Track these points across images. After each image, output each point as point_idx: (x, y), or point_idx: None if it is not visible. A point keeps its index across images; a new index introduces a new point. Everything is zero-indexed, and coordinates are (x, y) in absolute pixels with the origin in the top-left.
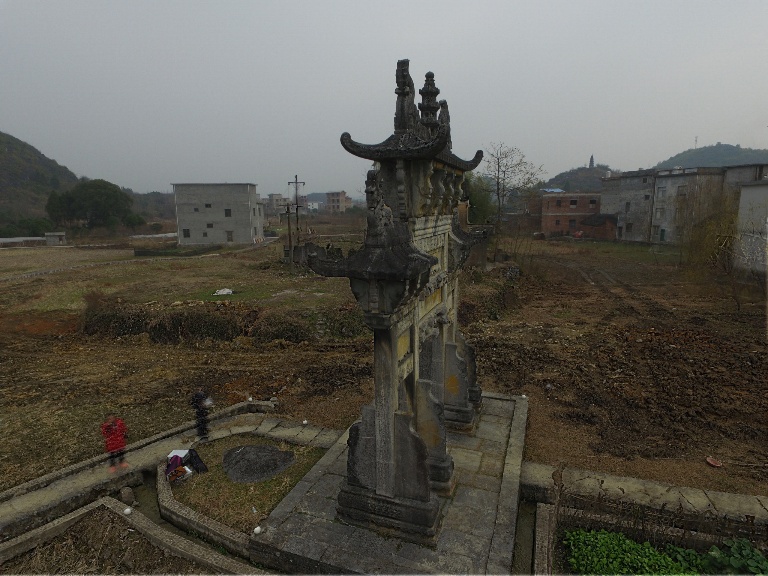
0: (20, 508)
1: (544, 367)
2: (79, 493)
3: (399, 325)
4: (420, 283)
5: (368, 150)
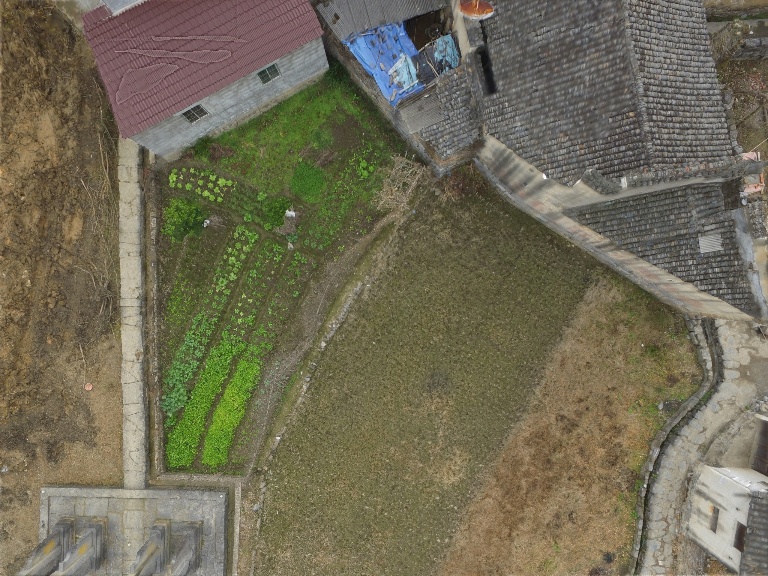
0: None
1: None
2: None
3: None
4: None
5: None
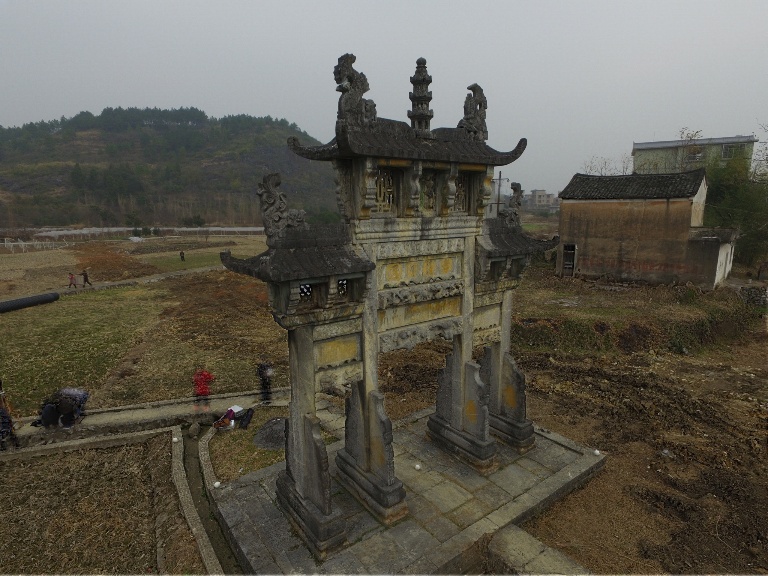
0: (135, 416)
1: (690, 427)
2: (167, 418)
3: (321, 329)
4: (360, 289)
5: (310, 152)
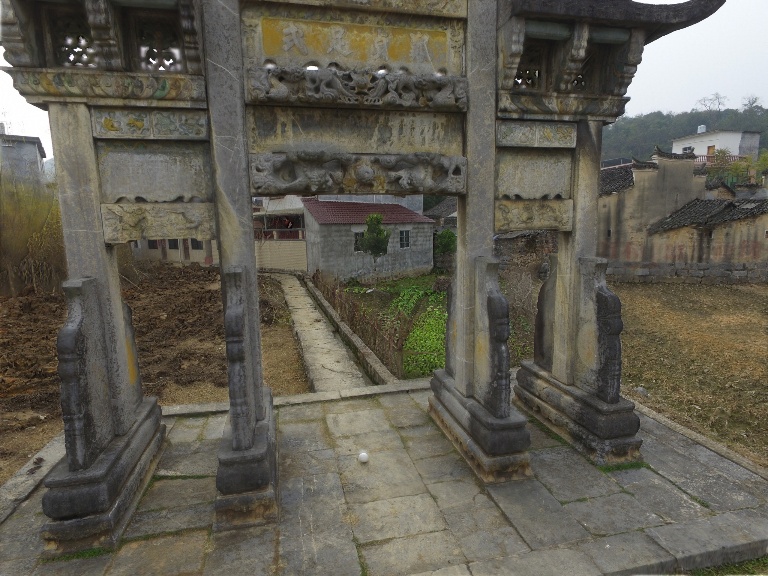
0: None
1: None
2: None
3: None
4: None
5: None
